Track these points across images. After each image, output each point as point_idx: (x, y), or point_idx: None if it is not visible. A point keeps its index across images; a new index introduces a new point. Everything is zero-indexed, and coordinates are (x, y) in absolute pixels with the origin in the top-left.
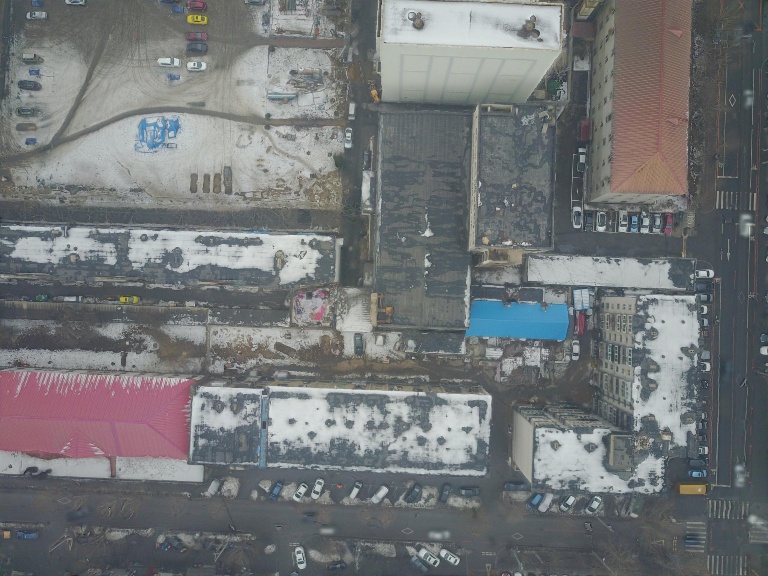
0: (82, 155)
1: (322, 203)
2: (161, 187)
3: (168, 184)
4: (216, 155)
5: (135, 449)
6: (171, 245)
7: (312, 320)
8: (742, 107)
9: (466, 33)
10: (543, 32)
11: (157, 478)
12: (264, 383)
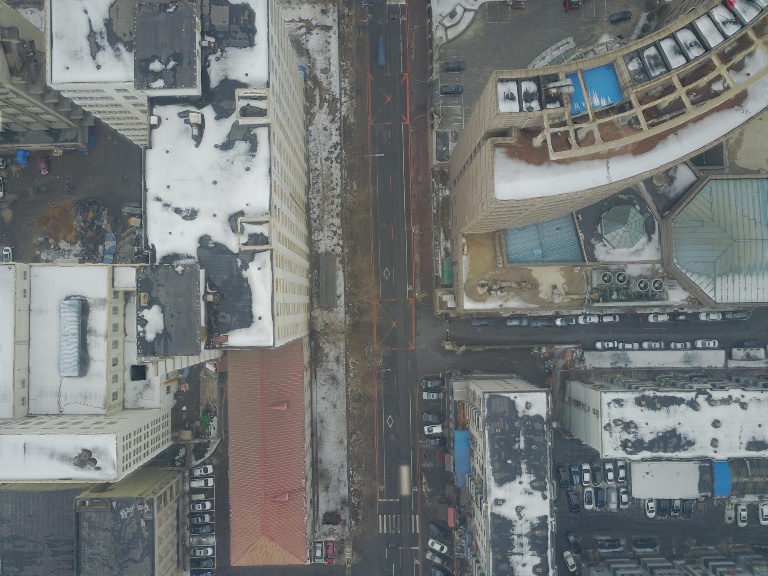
0: None
1: None
2: None
3: None
4: None
5: None
6: None
7: None
8: (400, 428)
9: (21, 466)
10: (100, 460)
11: None
12: None
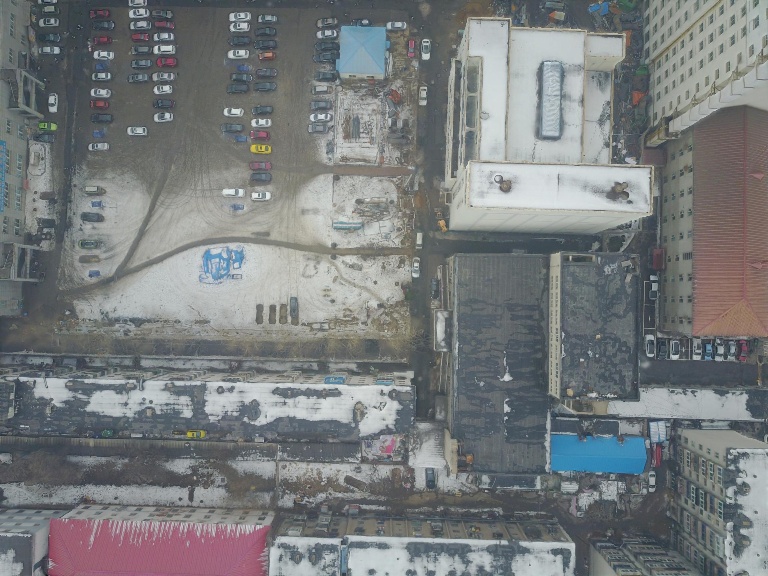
0: (146, 287)
1: (390, 333)
2: (226, 318)
3: (233, 315)
4: (282, 285)
5: None
6: (248, 397)
7: (382, 453)
8: None
9: (554, 196)
10: (632, 194)
11: None
12: (337, 522)
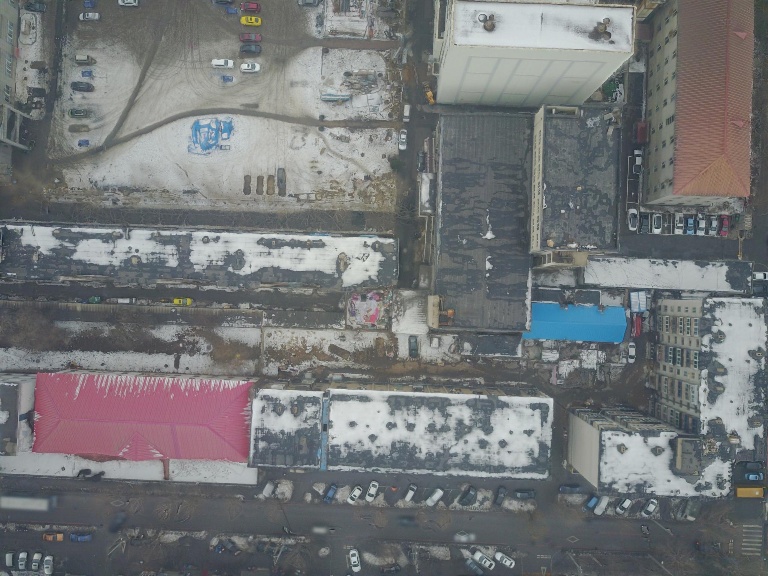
0: (135, 157)
1: (376, 205)
2: (214, 189)
3: (221, 186)
4: (270, 157)
5: (194, 452)
6: (233, 247)
7: (366, 322)
8: None
9: (537, 35)
10: (615, 34)
11: (211, 480)
12: (320, 385)
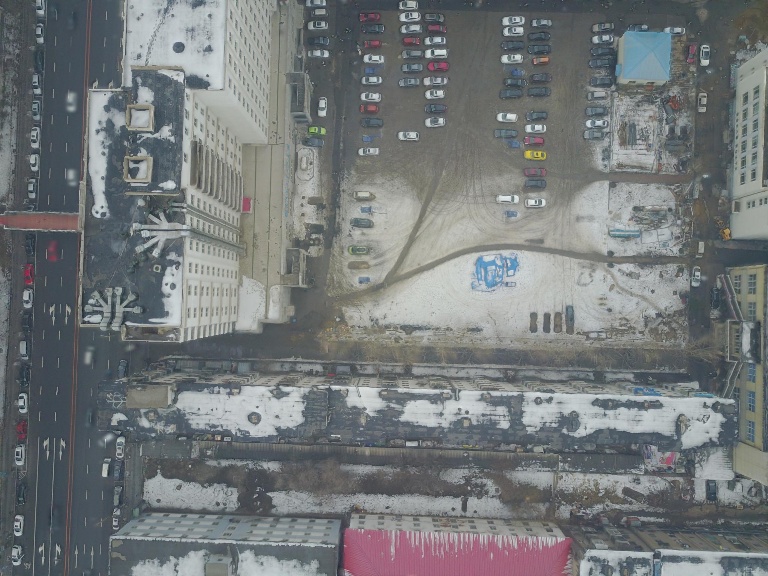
0: (417, 294)
1: (668, 343)
2: (500, 327)
3: (507, 323)
4: (556, 293)
5: None
6: (567, 408)
7: (662, 464)
8: None
9: None
10: None
11: None
12: (624, 534)
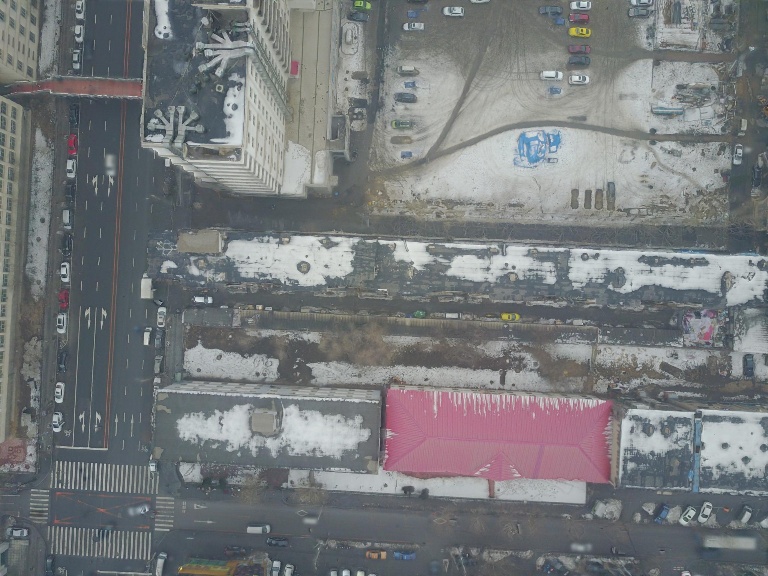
0: (459, 169)
1: (709, 220)
2: (541, 202)
3: (548, 199)
4: (598, 170)
5: (553, 472)
6: (613, 265)
7: (700, 340)
8: None
9: None
10: None
11: (537, 499)
12: None
